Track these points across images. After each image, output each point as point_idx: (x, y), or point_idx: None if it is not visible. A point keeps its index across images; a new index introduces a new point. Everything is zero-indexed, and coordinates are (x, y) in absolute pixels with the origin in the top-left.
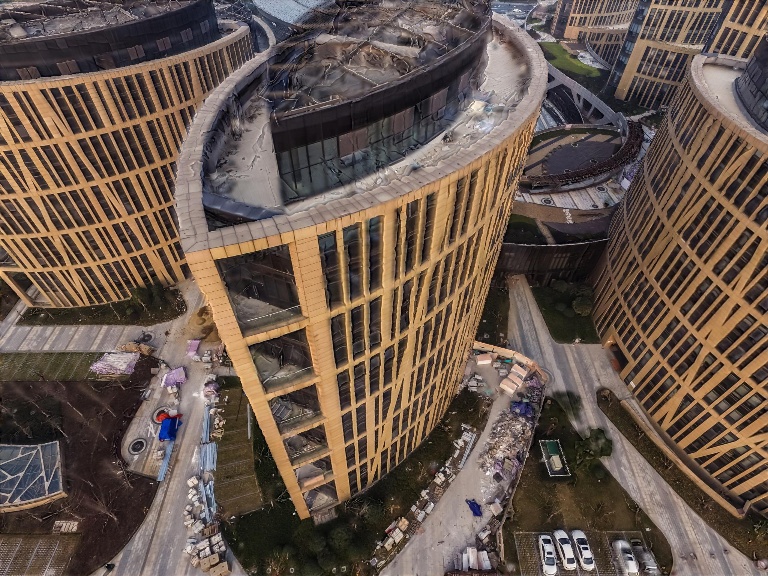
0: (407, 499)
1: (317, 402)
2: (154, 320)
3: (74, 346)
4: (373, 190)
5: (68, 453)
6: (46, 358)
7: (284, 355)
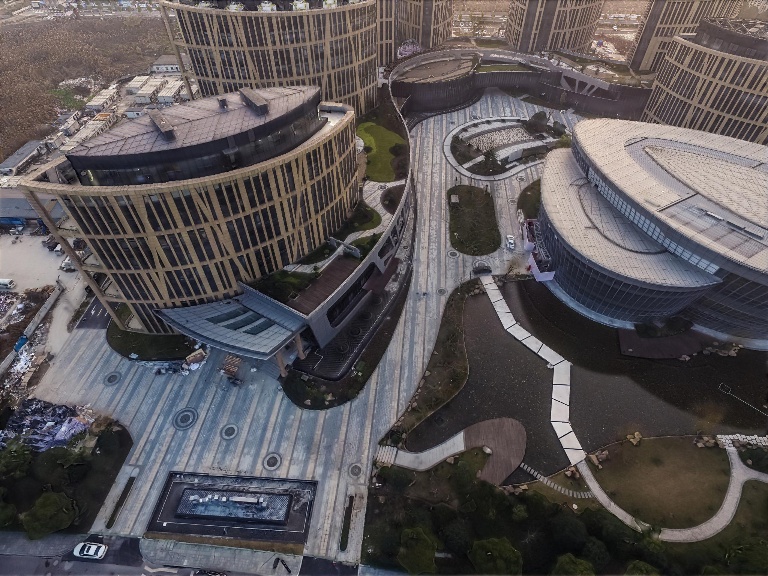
0: None
1: None
2: None
3: None
4: None
5: None
6: None
7: None
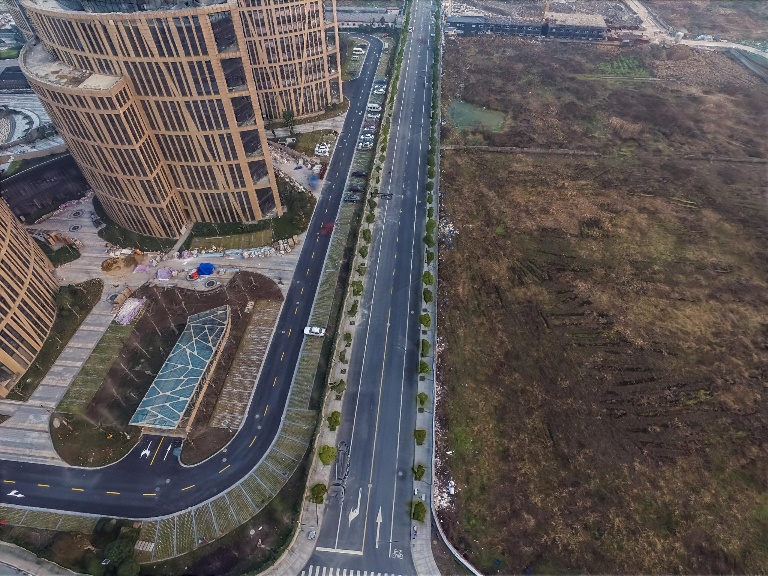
0: None
1: None
2: (96, 296)
3: (91, 343)
4: None
5: None
6: (93, 360)
7: None
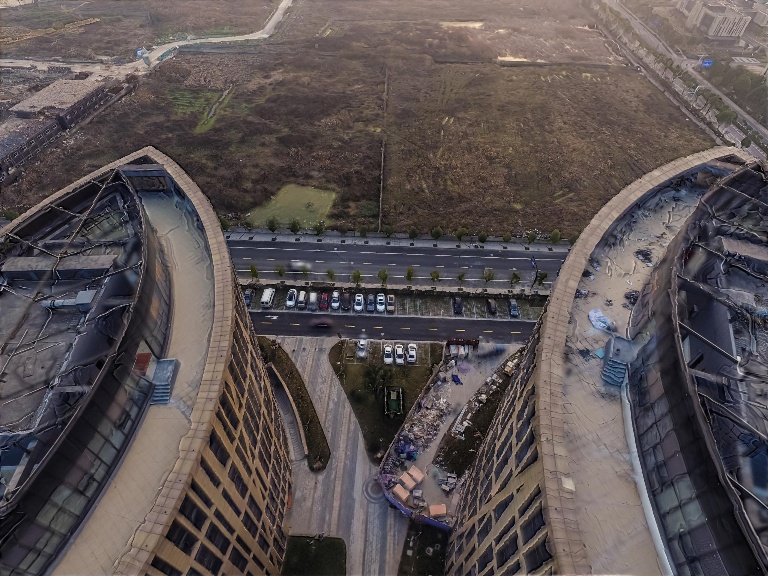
0: None
1: None
2: None
3: None
4: (667, 179)
5: None
6: None
7: None
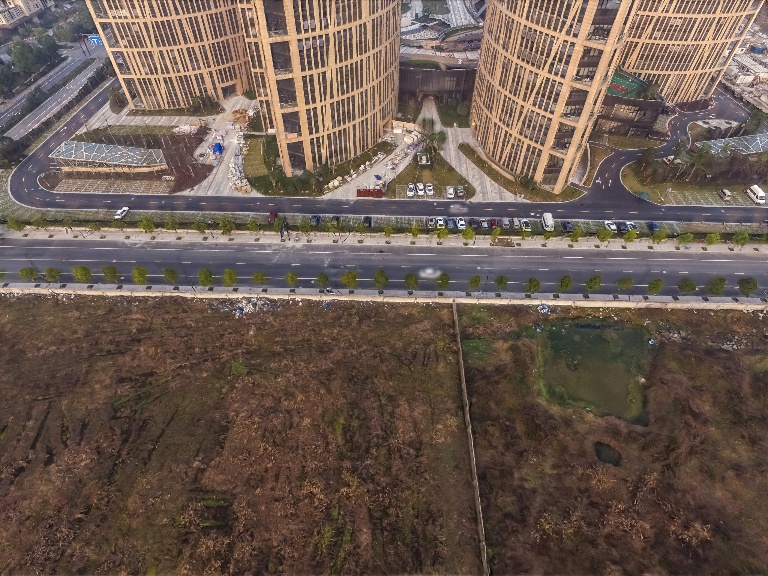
0: (343, 173)
1: (291, 66)
2: (206, 114)
3: (161, 123)
4: None
5: (166, 156)
6: (146, 127)
7: (276, 27)
